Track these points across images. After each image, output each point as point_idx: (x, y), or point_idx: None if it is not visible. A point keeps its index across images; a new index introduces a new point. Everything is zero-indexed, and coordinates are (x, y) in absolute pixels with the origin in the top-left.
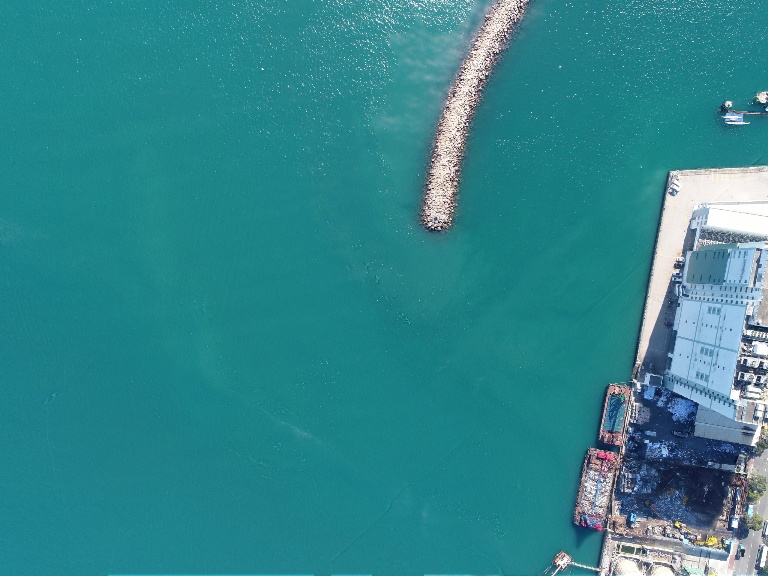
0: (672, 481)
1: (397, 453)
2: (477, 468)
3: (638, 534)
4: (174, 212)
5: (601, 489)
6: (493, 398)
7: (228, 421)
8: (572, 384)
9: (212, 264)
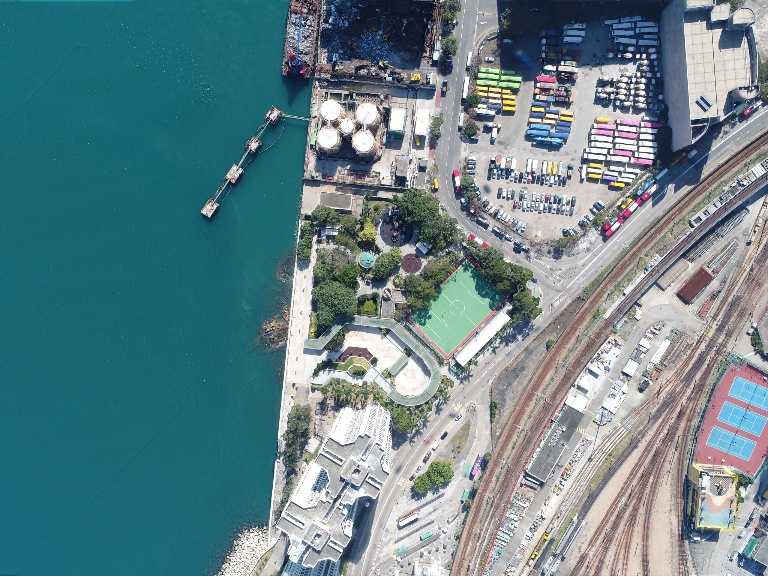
0: (373, 20)
1: None
2: None
3: (342, 76)
4: None
5: (303, 33)
6: None
7: None
8: None
9: None
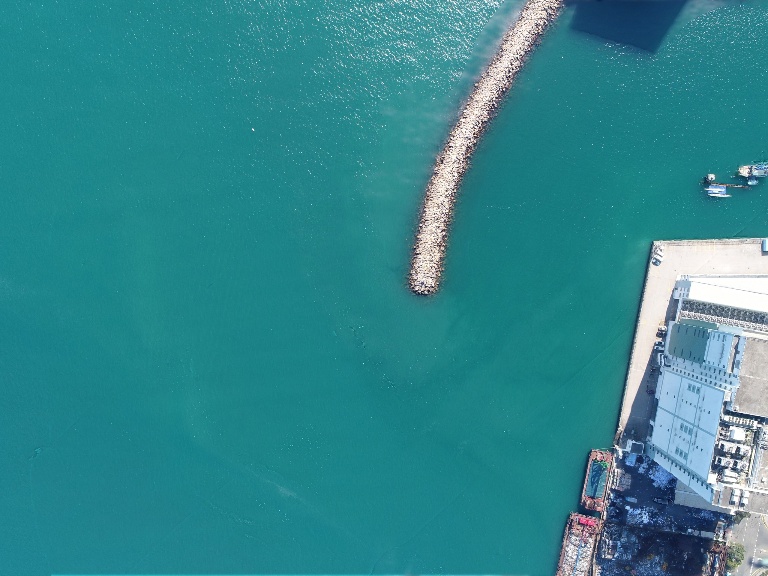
0: (652, 547)
1: (380, 518)
2: (459, 534)
3: None
4: (162, 274)
5: (582, 554)
6: (477, 461)
7: (213, 479)
8: (555, 449)
9: (199, 326)
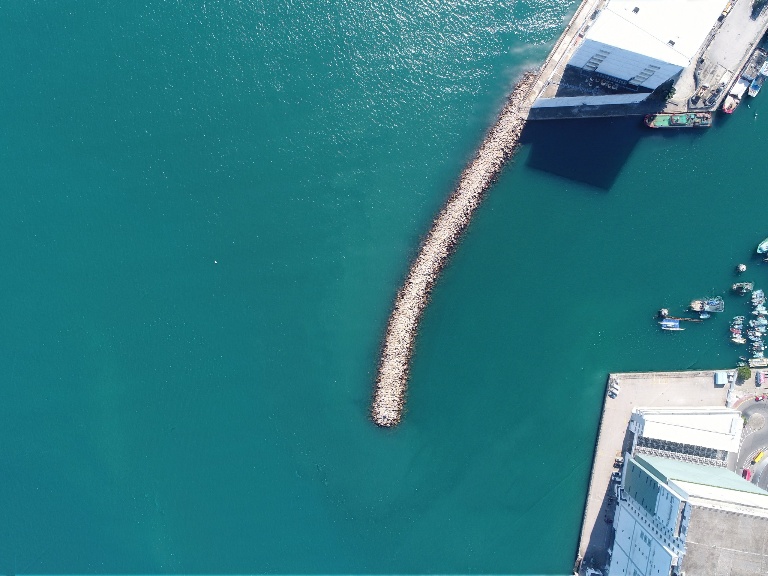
0: None
1: None
2: None
3: None
4: (125, 417)
5: None
6: None
7: None
8: None
9: (163, 466)
